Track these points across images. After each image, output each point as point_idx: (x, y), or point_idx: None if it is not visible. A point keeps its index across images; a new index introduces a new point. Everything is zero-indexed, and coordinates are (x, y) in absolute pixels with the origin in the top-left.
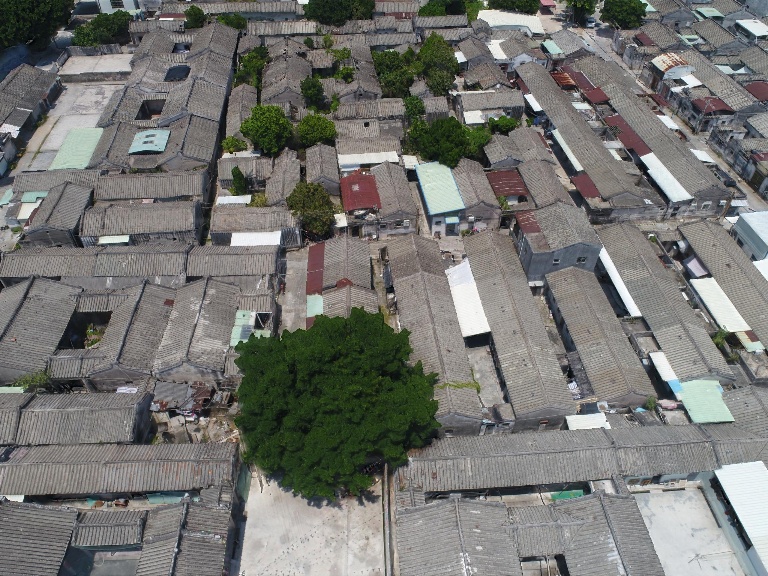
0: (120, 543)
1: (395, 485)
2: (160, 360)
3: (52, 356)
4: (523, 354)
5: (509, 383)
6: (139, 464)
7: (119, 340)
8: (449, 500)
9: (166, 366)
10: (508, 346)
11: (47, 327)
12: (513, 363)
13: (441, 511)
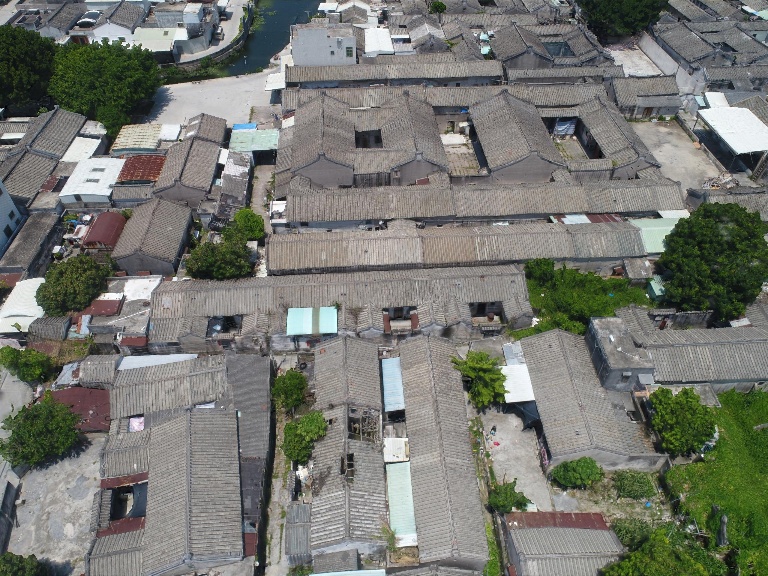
0: (557, 42)
1: (651, 34)
2: (531, 8)
3: (485, 6)
4: (688, 5)
5: (684, 13)
6: (549, 26)
7: (509, 2)
8: (681, 23)
9: (537, 7)
10: (679, 5)
11: (473, 0)
12: (684, 8)
13: (678, 28)
